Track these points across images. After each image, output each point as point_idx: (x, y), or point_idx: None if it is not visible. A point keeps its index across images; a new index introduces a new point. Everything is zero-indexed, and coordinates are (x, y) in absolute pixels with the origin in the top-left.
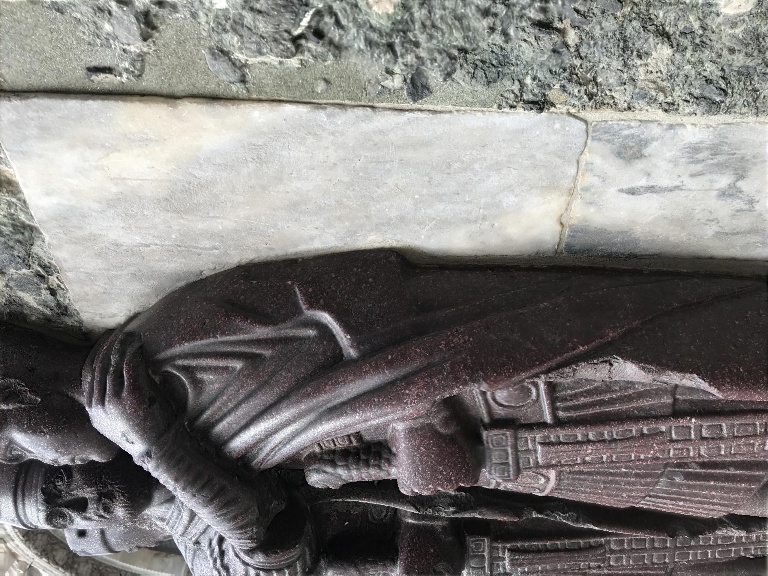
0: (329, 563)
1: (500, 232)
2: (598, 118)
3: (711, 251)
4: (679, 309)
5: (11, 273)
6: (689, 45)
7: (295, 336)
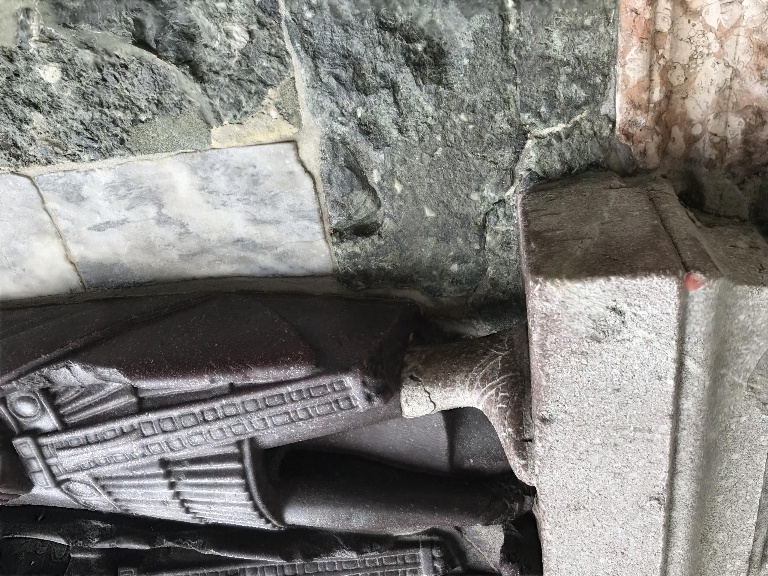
0: None
1: (32, 275)
2: (35, 173)
3: (189, 273)
4: (139, 320)
5: None
6: (50, 110)
7: None
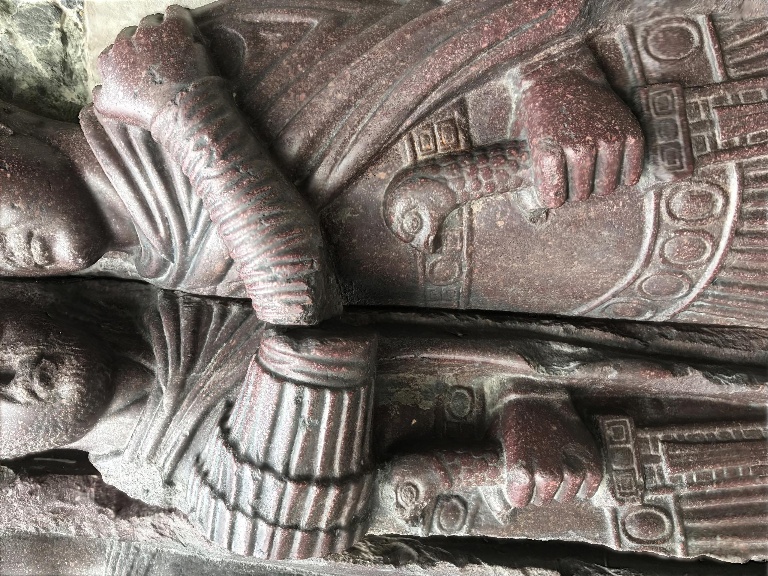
0: (395, 462)
1: None
2: None
3: None
4: None
5: (20, 5)
6: None
7: (388, 2)
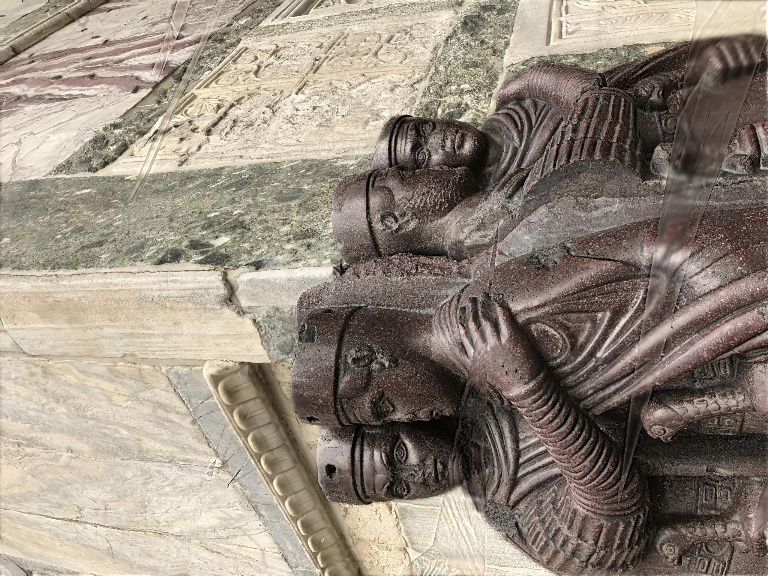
0: None
1: None
2: None
3: None
4: None
5: None
6: None
7: None
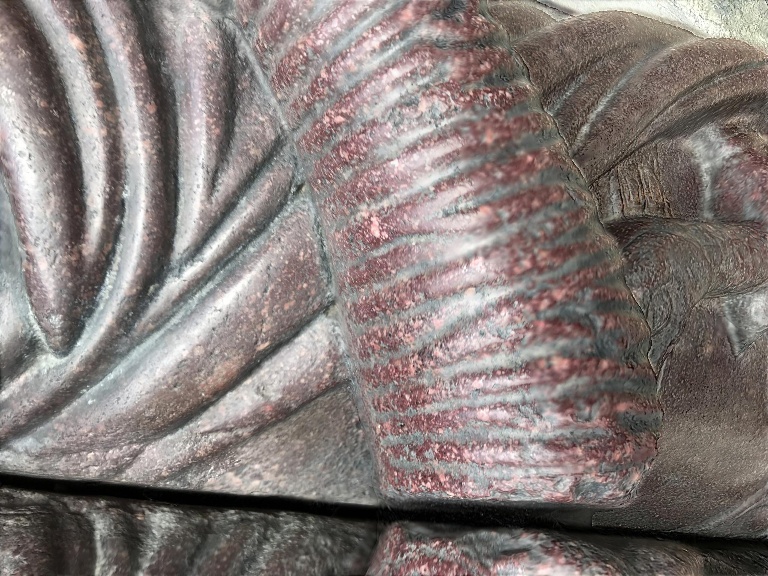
0: None
1: None
2: (661, 2)
3: None
4: None
5: None
6: None
7: None
